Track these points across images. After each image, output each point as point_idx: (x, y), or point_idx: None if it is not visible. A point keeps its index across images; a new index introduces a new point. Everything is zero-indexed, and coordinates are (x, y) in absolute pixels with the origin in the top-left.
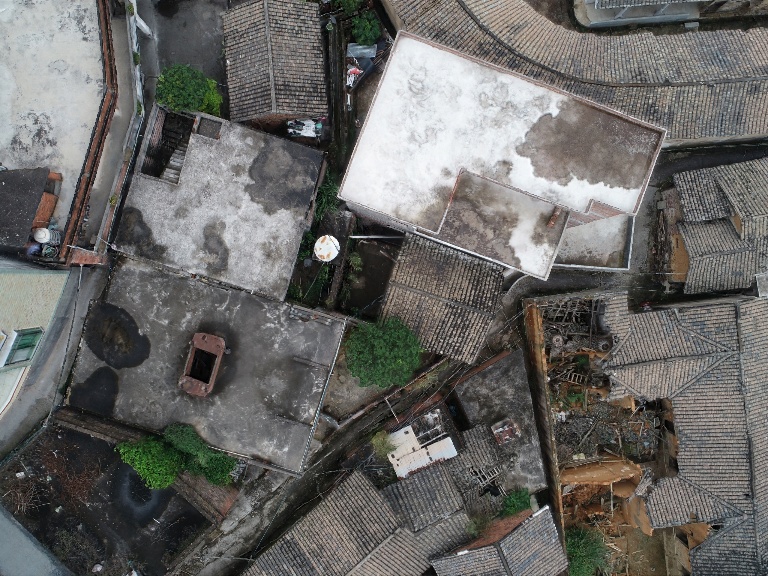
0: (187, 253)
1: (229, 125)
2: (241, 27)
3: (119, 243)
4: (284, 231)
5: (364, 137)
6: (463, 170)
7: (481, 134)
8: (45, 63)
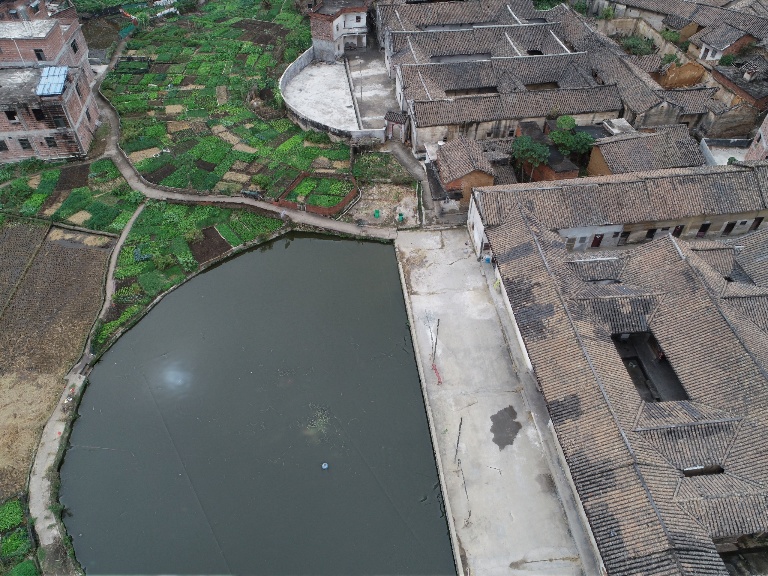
0: None
1: None
2: None
3: None
4: None
5: None
6: None
7: None
8: None
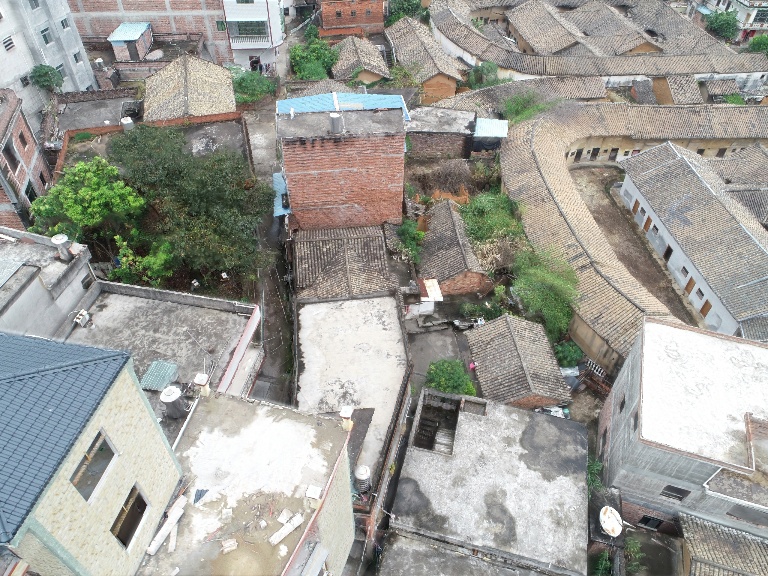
0: (470, 523)
1: (493, 404)
2: (486, 338)
3: (396, 514)
4: (568, 497)
5: (643, 391)
6: (749, 413)
7: (747, 387)
8: (351, 345)
